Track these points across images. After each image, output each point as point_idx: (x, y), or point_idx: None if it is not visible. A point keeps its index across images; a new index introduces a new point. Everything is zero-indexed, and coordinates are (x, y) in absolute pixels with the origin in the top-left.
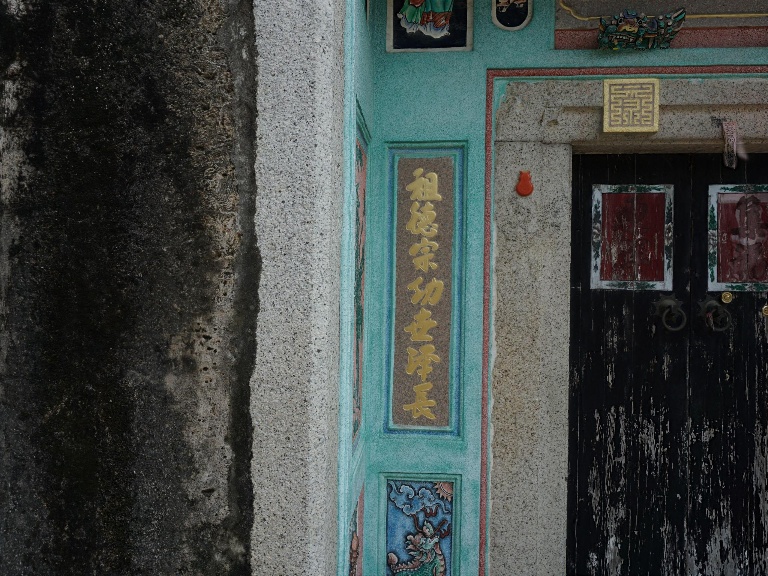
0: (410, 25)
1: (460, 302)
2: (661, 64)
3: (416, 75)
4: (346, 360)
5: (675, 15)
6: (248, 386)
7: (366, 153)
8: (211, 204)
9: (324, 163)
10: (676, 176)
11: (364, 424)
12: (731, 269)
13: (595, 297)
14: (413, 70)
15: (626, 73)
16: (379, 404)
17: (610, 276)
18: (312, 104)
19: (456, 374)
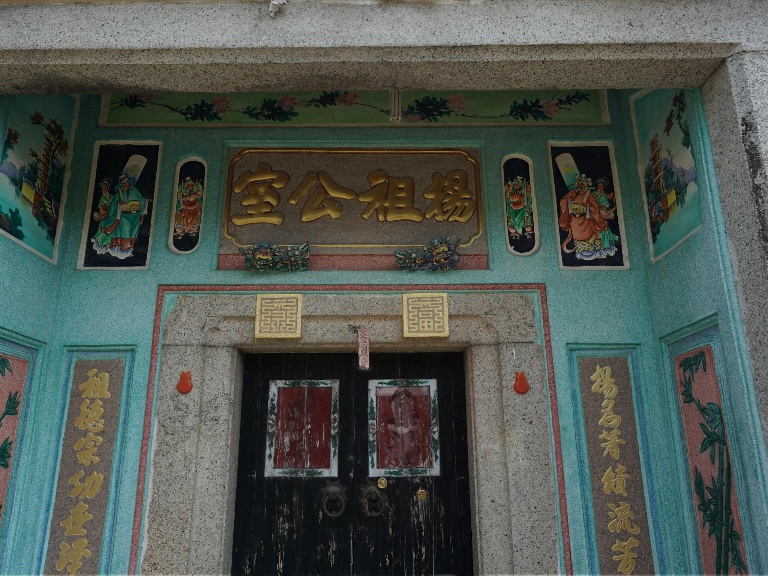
0: (101, 248)
1: (116, 495)
2: (301, 283)
3: (98, 289)
4: None
5: (302, 247)
6: None
7: (36, 357)
8: None
9: None
10: (341, 372)
11: None
12: (389, 456)
13: (268, 485)
14: (96, 285)
15: (274, 290)
16: None
17: (282, 464)
18: None
19: (105, 569)
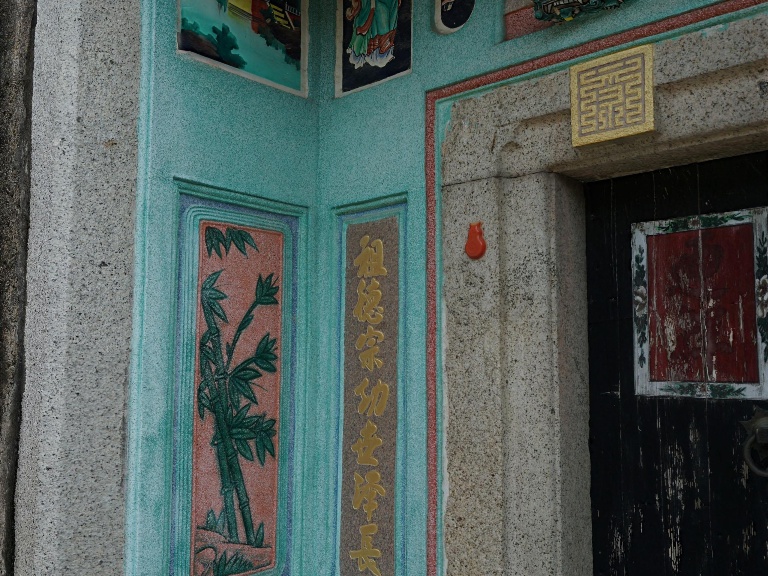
0: (358, 59)
1: None
2: (646, 21)
3: (357, 119)
4: (133, 481)
5: None
6: (14, 500)
7: (297, 227)
8: (6, 316)
9: (59, 267)
10: None
11: (298, 569)
12: None
13: (643, 409)
14: (355, 114)
15: (597, 49)
16: (325, 545)
17: (665, 374)
18: (50, 209)
19: (402, 516)
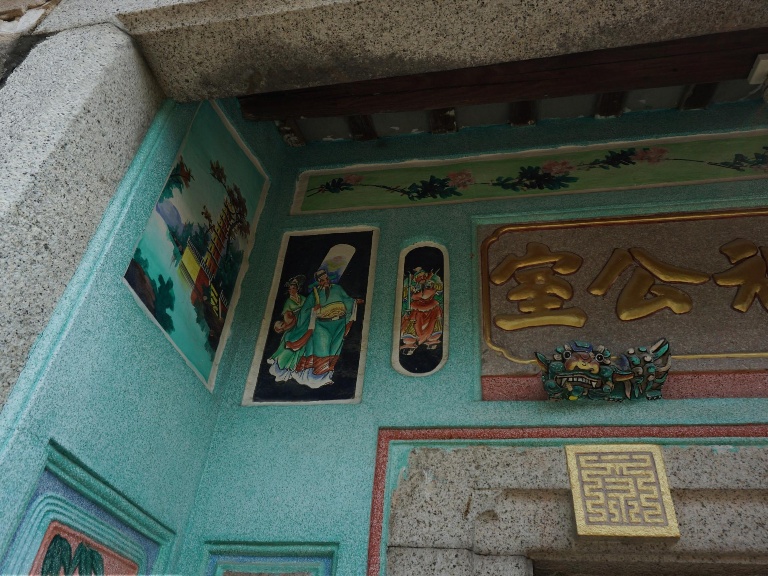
0: (282, 372)
1: None
2: (655, 422)
3: (274, 436)
4: None
5: (653, 348)
6: None
7: (154, 560)
8: None
9: None
10: None
11: None
12: None
13: None
14: (271, 429)
15: (600, 435)
16: None
17: None
18: None
19: None
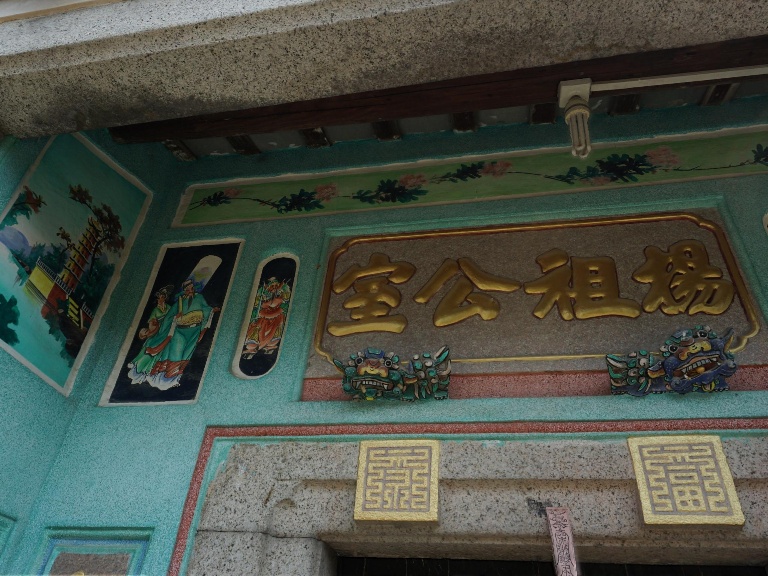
0: (138, 376)
1: None
2: (437, 419)
3: (118, 434)
4: None
5: (437, 354)
6: None
7: None
8: None
9: None
10: None
11: None
12: None
13: None
14: (117, 428)
15: (390, 432)
16: None
17: None
18: None
19: None
